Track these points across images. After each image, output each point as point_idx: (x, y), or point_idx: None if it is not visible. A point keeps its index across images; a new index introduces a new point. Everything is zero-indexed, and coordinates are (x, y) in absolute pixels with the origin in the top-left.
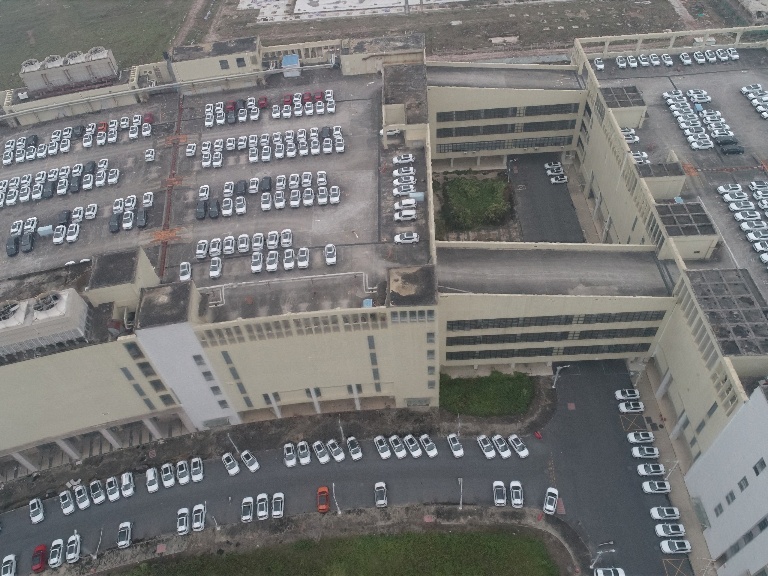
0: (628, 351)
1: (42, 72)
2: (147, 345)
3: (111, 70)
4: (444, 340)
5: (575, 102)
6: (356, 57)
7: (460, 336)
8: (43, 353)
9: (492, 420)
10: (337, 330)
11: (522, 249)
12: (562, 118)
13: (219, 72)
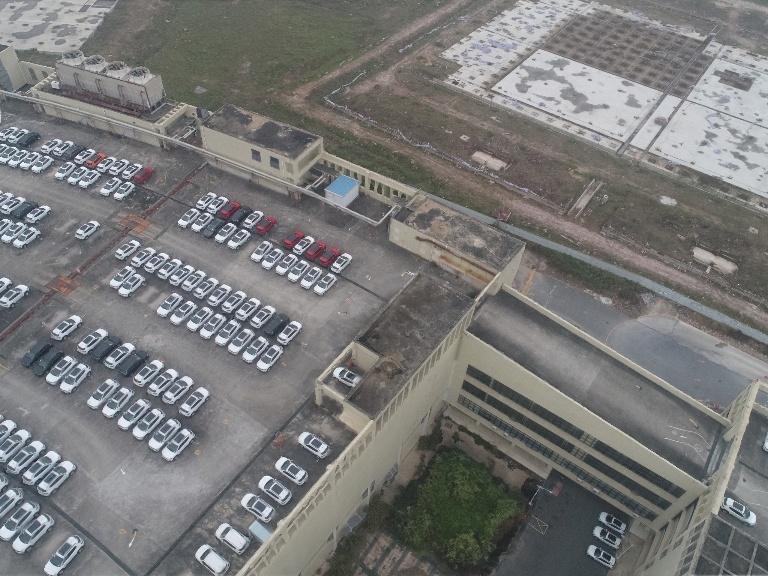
0: None
1: (76, 70)
2: None
3: (142, 101)
4: None
5: (679, 485)
6: (410, 230)
7: None
8: None
9: None
10: None
11: None
12: (650, 487)
13: (249, 160)
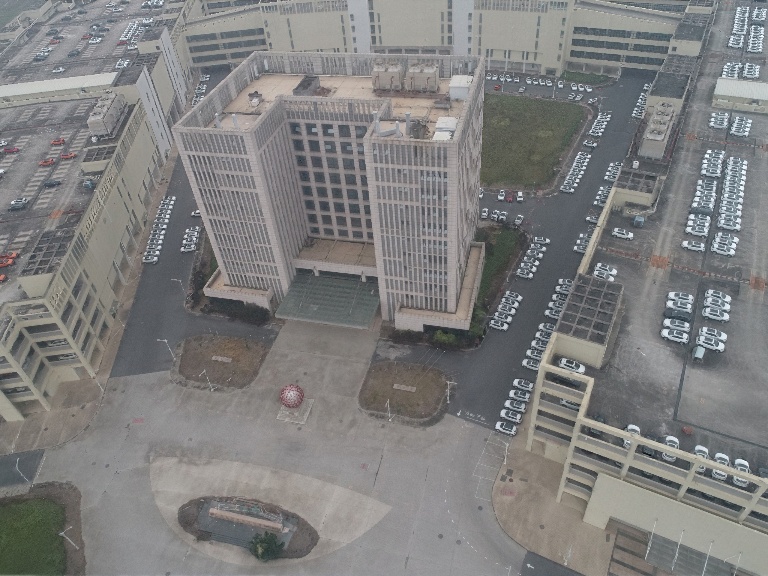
0: (657, 65)
1: None
2: (455, 2)
3: None
4: (571, 41)
5: None
6: None
7: (579, 39)
8: None
9: (582, 83)
10: (527, 10)
11: (620, 8)
12: None
13: None
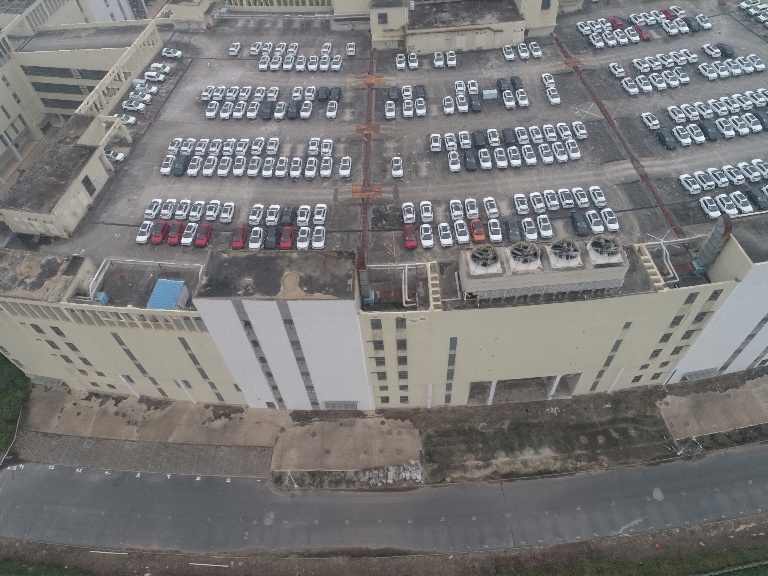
0: None
1: None
2: None
3: None
4: None
5: None
6: None
7: None
8: None
9: None
10: None
11: None
12: None
13: None
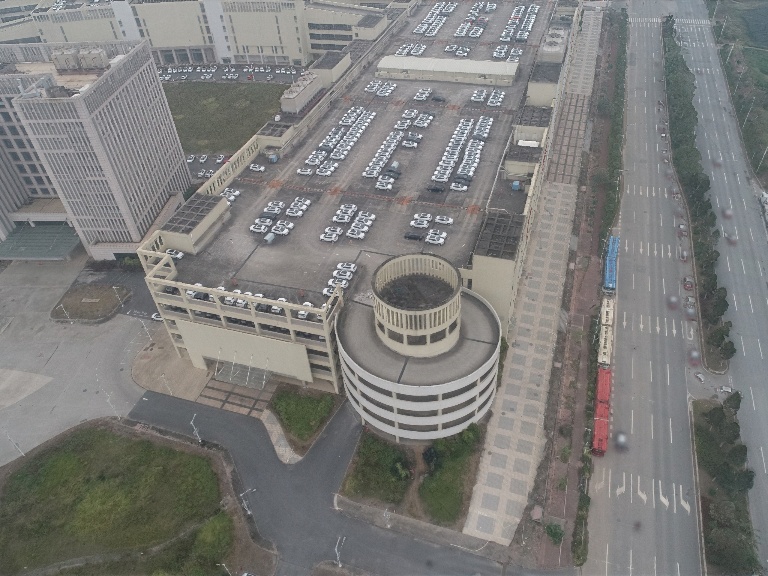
0: None
1: None
2: (207, 6)
3: None
4: (309, 35)
5: None
6: None
7: (314, 33)
8: (176, 1)
9: None
10: (265, 11)
11: None
12: None
13: None
